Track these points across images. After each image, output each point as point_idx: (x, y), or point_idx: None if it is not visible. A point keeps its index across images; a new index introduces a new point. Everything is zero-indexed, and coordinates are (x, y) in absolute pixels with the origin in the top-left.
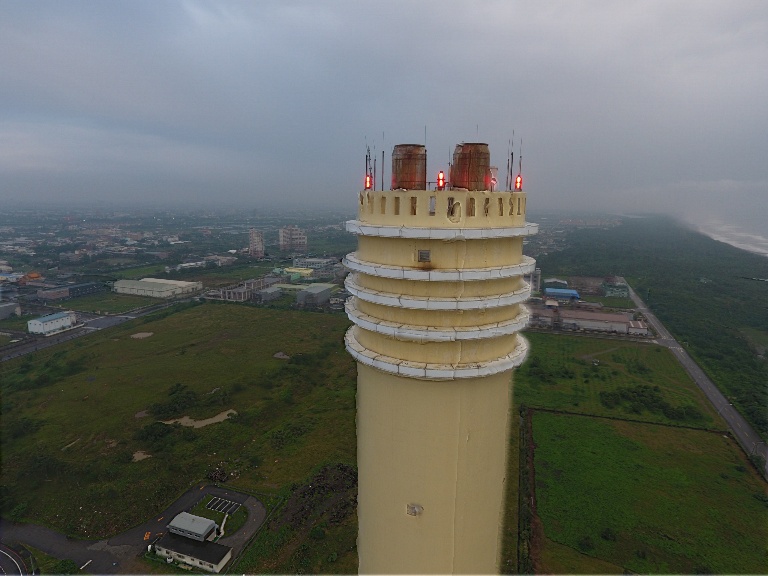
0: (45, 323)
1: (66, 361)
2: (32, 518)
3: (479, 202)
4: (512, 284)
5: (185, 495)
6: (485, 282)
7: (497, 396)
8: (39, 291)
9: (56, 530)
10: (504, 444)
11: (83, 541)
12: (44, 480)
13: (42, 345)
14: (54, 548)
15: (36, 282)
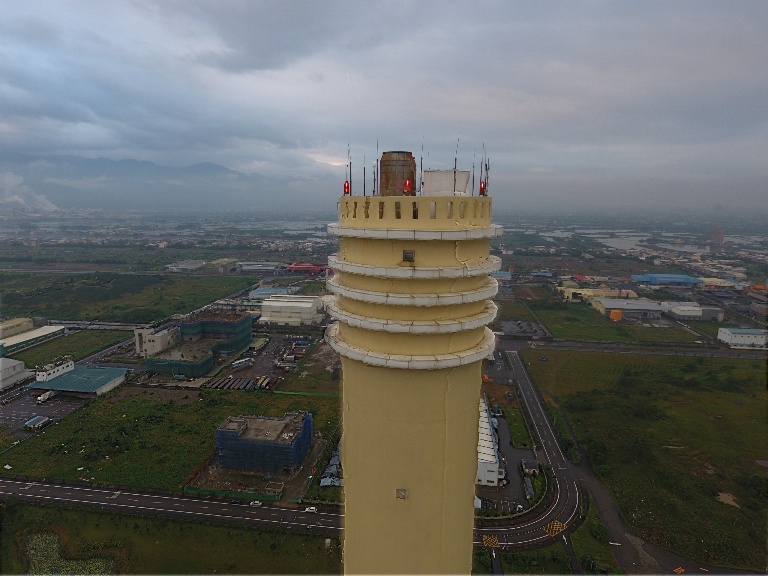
0: (734, 334)
1: (728, 376)
2: (608, 481)
3: (340, 205)
4: (364, 283)
5: (750, 573)
6: (342, 273)
7: (368, 389)
8: (753, 303)
9: (616, 502)
10: (399, 457)
11: (627, 526)
12: (633, 460)
13: (721, 354)
14: (605, 513)
15: (758, 294)
